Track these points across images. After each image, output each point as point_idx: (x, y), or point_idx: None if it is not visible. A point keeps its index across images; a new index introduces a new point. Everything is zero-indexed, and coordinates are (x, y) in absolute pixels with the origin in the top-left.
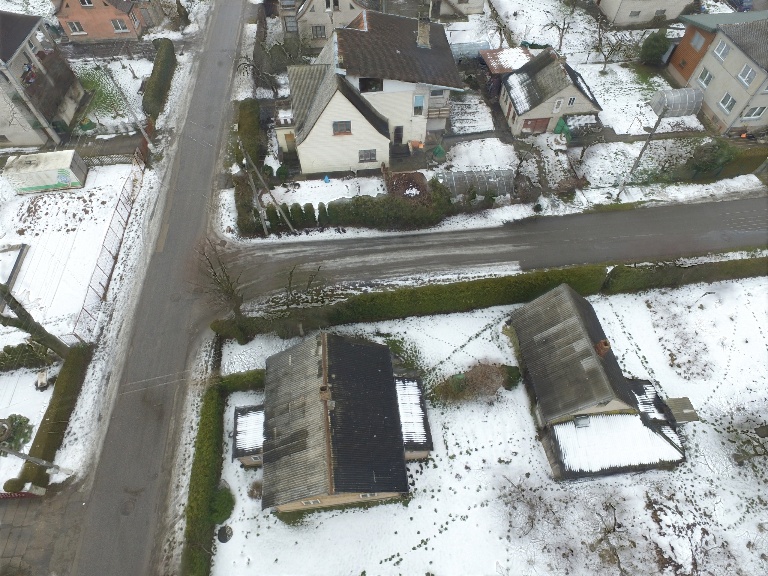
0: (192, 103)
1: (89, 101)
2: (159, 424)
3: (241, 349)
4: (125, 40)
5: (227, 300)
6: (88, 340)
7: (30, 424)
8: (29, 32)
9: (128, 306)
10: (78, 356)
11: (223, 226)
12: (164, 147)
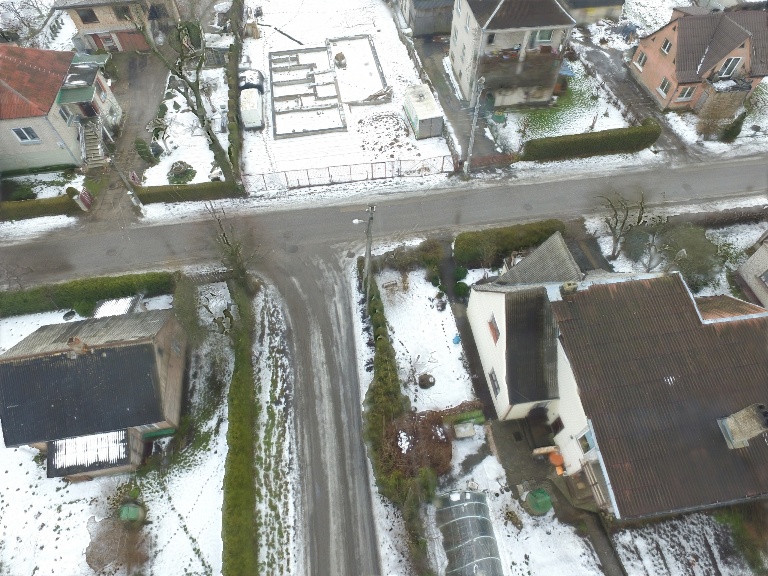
0: (565, 182)
1: (539, 108)
2: (169, 254)
3: (226, 295)
4: (656, 101)
5: (224, 258)
6: (249, 190)
7: (187, 182)
8: (542, 25)
9: (282, 205)
10: (229, 188)
11: (374, 250)
12: (483, 178)
